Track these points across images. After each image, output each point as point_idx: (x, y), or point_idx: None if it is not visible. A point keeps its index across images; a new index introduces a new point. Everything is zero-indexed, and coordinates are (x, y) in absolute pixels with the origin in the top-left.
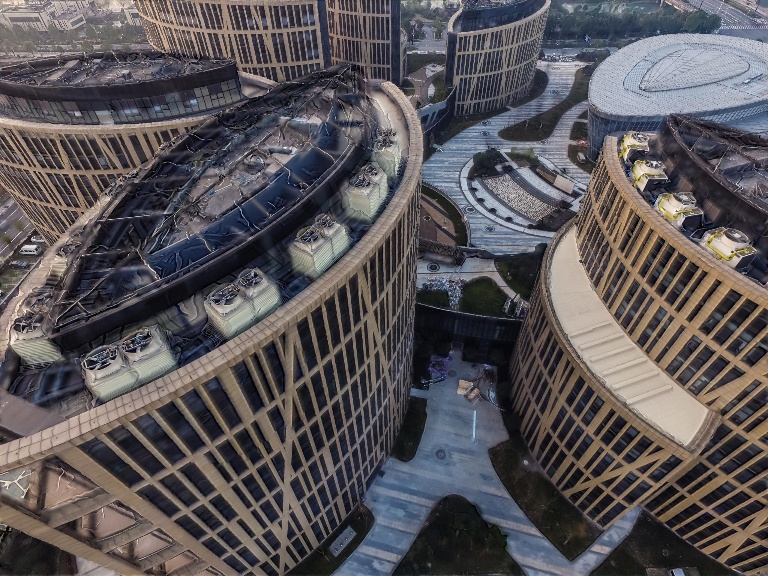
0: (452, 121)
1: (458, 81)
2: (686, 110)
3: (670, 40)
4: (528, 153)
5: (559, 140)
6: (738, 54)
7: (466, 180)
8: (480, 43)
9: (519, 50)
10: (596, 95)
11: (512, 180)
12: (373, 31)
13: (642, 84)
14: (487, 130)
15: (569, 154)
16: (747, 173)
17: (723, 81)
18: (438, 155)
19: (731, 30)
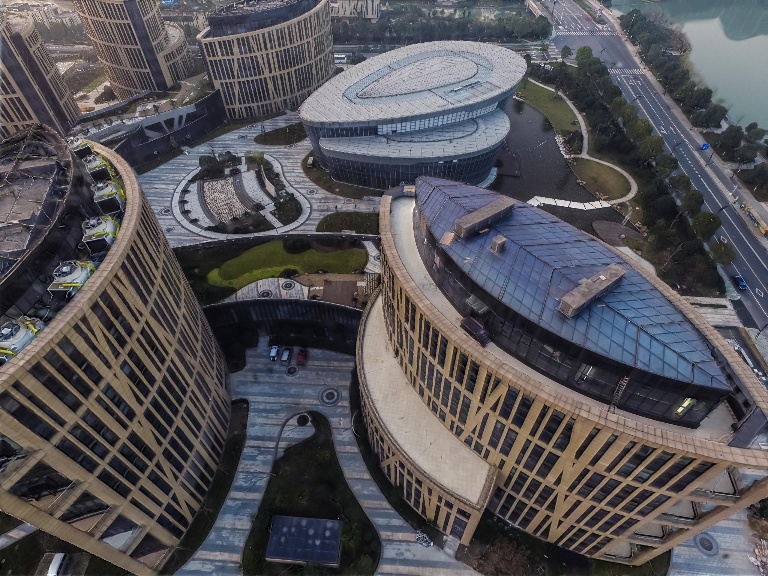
0: (221, 124)
1: (219, 85)
2: (375, 117)
3: (430, 47)
4: (256, 157)
5: (307, 144)
6: (477, 62)
7: (186, 182)
8: (228, 49)
9: (279, 56)
10: (311, 101)
11: (232, 183)
12: (121, 36)
13: (362, 91)
14: (247, 134)
15: (305, 158)
16: (18, 181)
17: (437, 88)
18: (181, 158)
19: (567, 36)
